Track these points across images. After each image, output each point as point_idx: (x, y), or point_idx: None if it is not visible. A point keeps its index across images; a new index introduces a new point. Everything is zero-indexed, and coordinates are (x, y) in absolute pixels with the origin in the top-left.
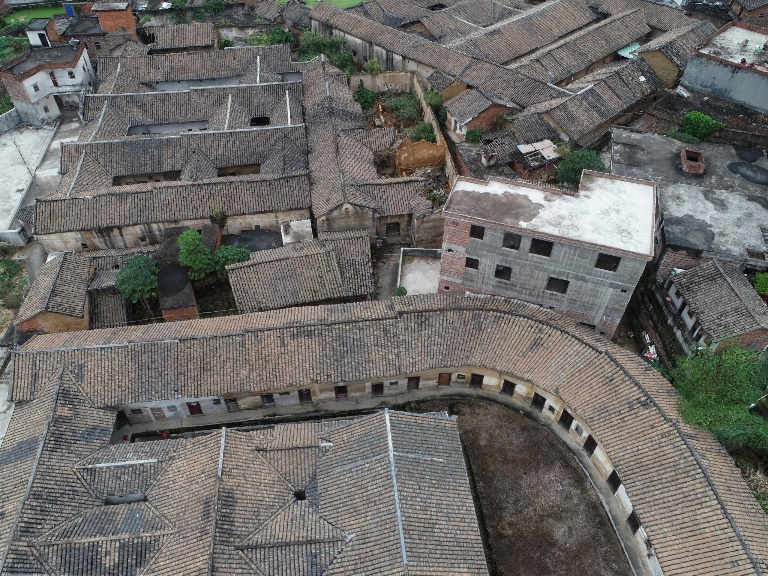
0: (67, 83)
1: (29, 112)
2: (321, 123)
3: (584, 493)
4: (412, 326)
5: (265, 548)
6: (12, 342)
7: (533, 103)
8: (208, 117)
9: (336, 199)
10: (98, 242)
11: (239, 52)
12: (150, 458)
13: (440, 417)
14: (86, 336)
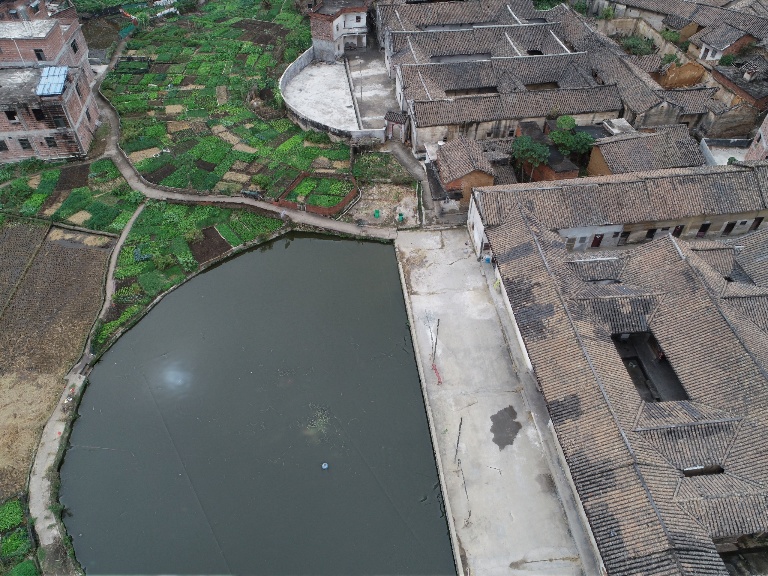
0: (352, 26)
1: (326, 49)
2: (597, 52)
3: None
4: (767, 175)
5: (739, 298)
6: (441, 197)
7: (765, 37)
8: (491, 50)
9: (652, 100)
10: (456, 136)
11: (491, 2)
12: (611, 257)
13: None
14: (516, 186)
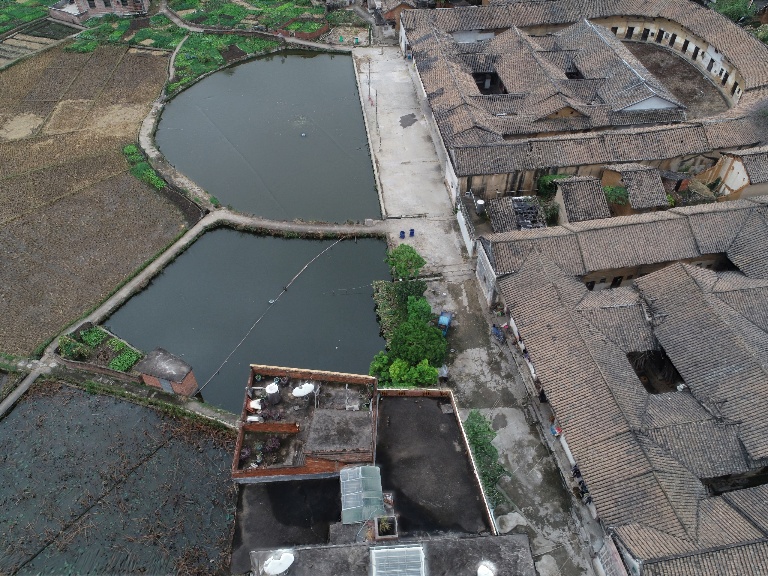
0: None
1: None
2: None
3: (671, 56)
4: (585, 1)
5: (548, 52)
6: (382, 23)
7: None
8: None
9: None
10: None
11: None
12: None
13: (605, 28)
14: None
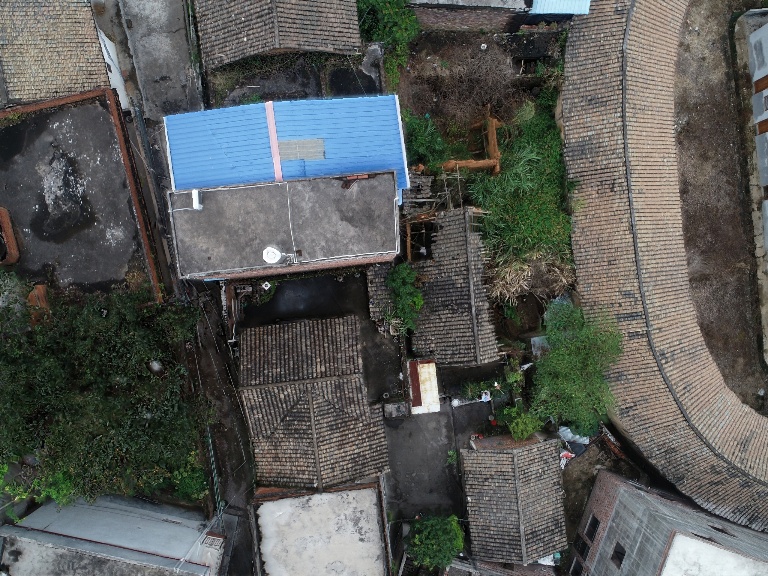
0: None
1: None
2: None
3: None
4: None
5: None
6: None
7: None
8: None
9: None
10: None
11: None
12: None
13: None
14: None
